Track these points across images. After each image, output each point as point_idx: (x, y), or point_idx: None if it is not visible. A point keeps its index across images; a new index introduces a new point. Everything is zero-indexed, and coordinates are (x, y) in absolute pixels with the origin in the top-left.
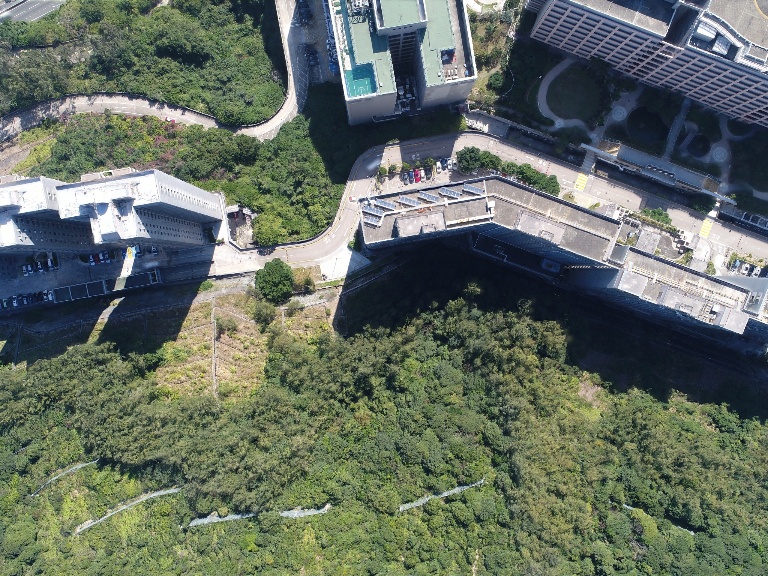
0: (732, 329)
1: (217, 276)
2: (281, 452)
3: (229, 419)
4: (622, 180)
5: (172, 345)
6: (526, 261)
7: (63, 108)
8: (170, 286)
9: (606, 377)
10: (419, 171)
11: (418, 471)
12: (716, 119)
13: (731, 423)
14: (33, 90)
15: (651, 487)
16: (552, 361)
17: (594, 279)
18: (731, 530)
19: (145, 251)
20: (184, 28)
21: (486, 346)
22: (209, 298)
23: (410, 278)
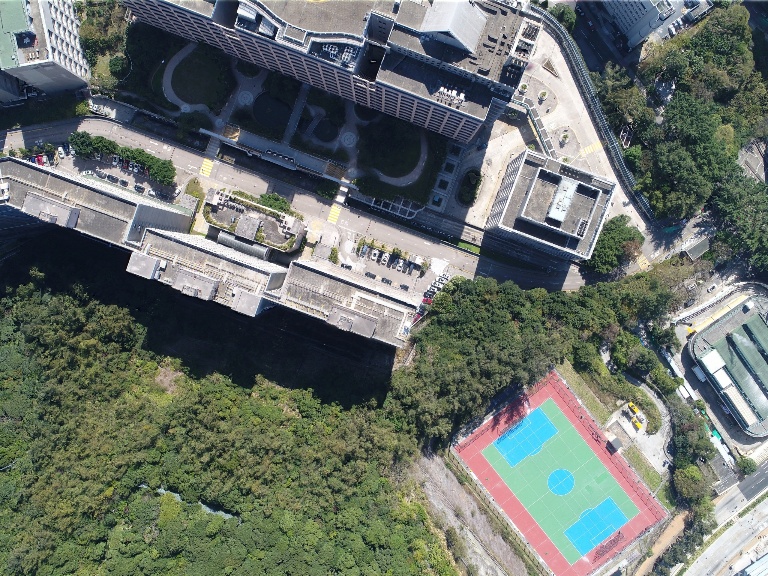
0: (244, 311)
1: None
2: None
3: None
4: (248, 165)
5: None
6: None
7: None
8: None
9: (190, 362)
10: (42, 156)
11: None
12: (337, 104)
13: (311, 408)
14: None
15: (185, 471)
16: (117, 346)
17: None
18: (263, 514)
19: None
20: None
21: None
22: None
23: (17, 264)
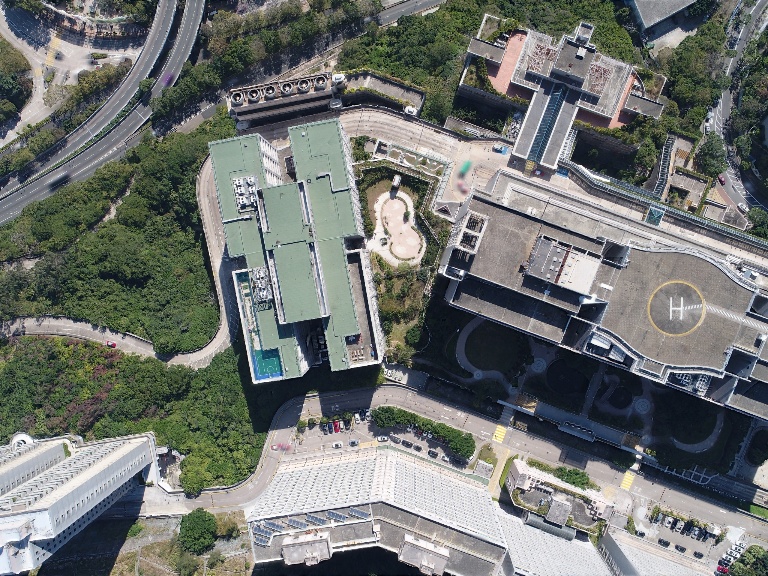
0: None
1: (147, 516)
2: None
3: None
4: (541, 432)
5: None
6: None
7: (14, 327)
8: (104, 521)
9: None
10: (338, 422)
11: None
12: (636, 376)
13: None
14: None
15: None
16: None
17: None
18: None
19: None
20: (126, 251)
21: None
22: (135, 547)
23: None
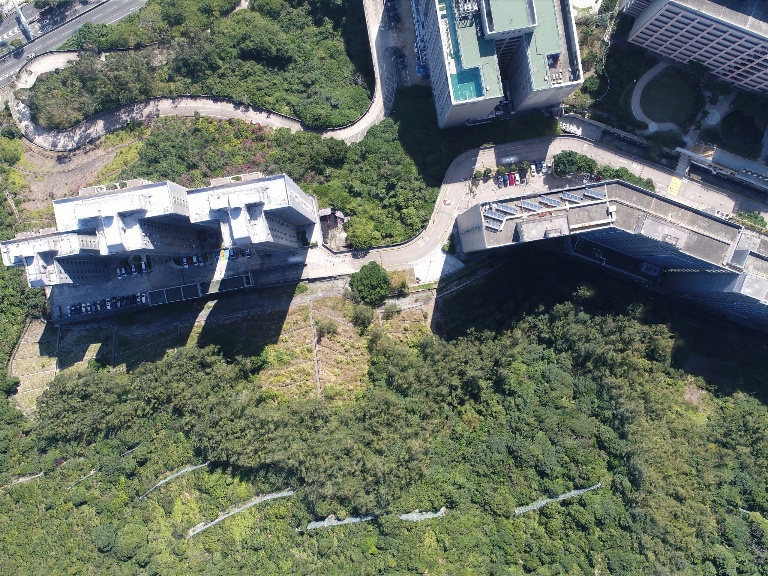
0: None
1: (310, 279)
2: (397, 455)
3: (339, 422)
4: (715, 184)
5: (274, 348)
6: (625, 264)
7: (147, 111)
8: (262, 289)
9: (710, 380)
10: (513, 174)
11: (532, 474)
12: None
13: None
14: (119, 93)
15: (767, 490)
16: (660, 365)
17: (704, 283)
18: None
19: (238, 254)
20: (268, 31)
21: (600, 350)
22: (306, 301)
23: (508, 281)
